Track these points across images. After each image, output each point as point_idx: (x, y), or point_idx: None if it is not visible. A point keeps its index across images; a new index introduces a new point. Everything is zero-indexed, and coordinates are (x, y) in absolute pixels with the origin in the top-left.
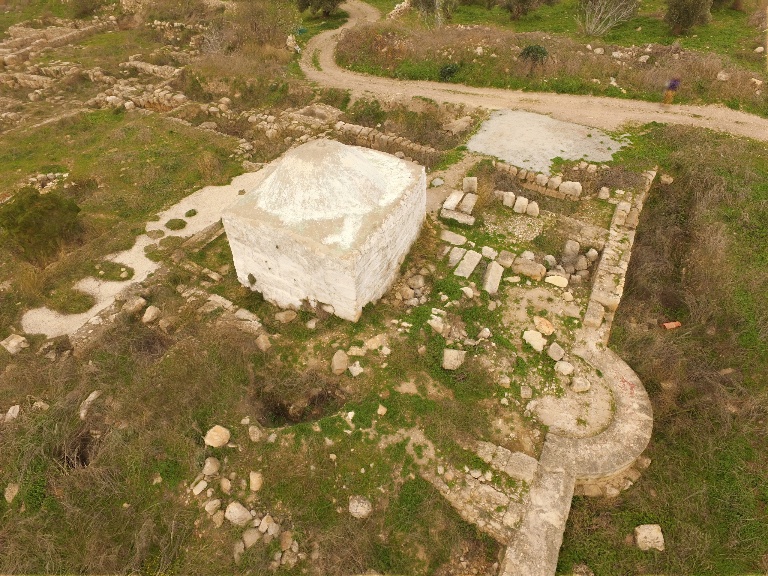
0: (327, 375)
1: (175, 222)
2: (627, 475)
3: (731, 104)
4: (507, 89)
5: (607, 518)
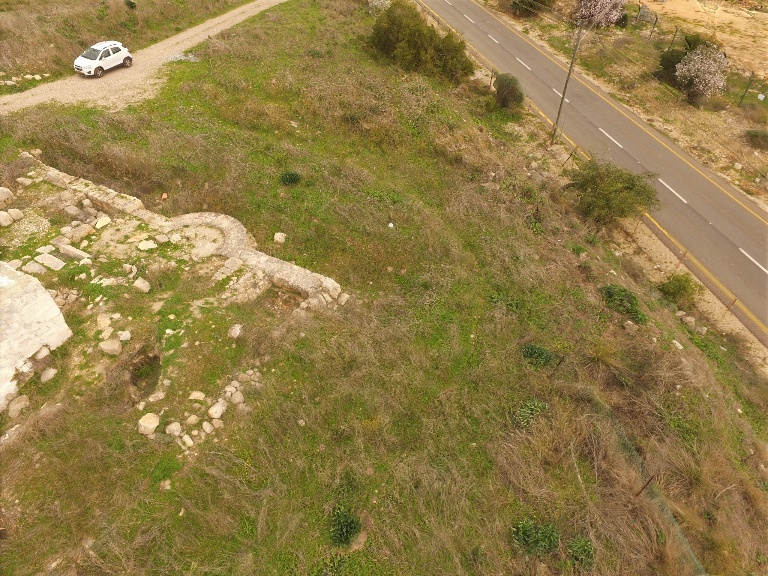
0: (117, 360)
1: None
2: (248, 237)
3: None
4: None
5: (267, 250)
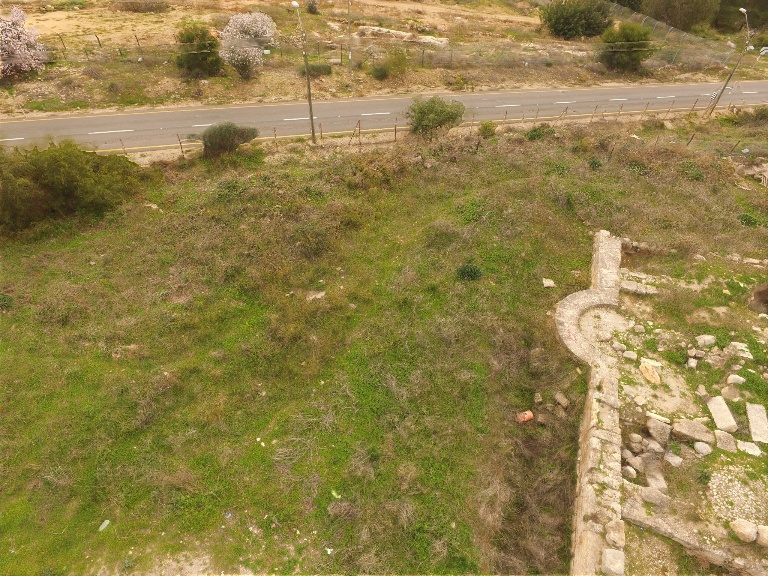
0: None
1: None
2: None
3: None
4: None
5: None
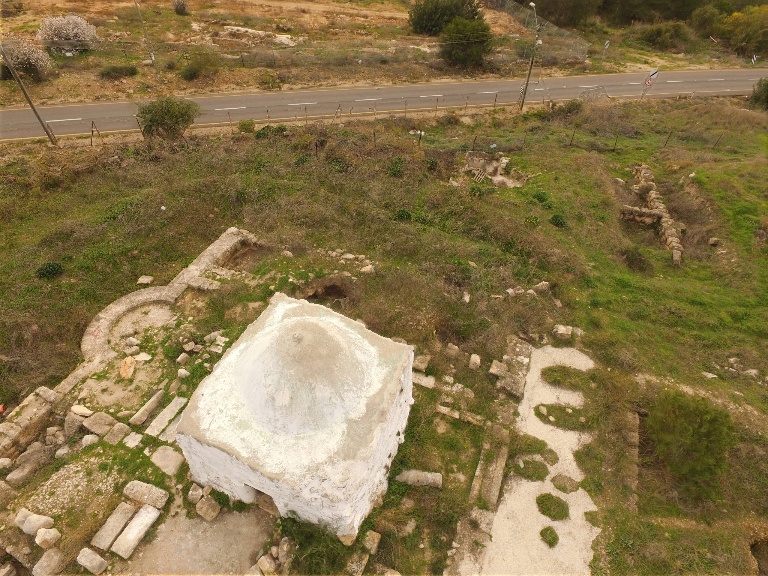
0: None
1: (557, 510)
2: None
3: None
4: None
5: None
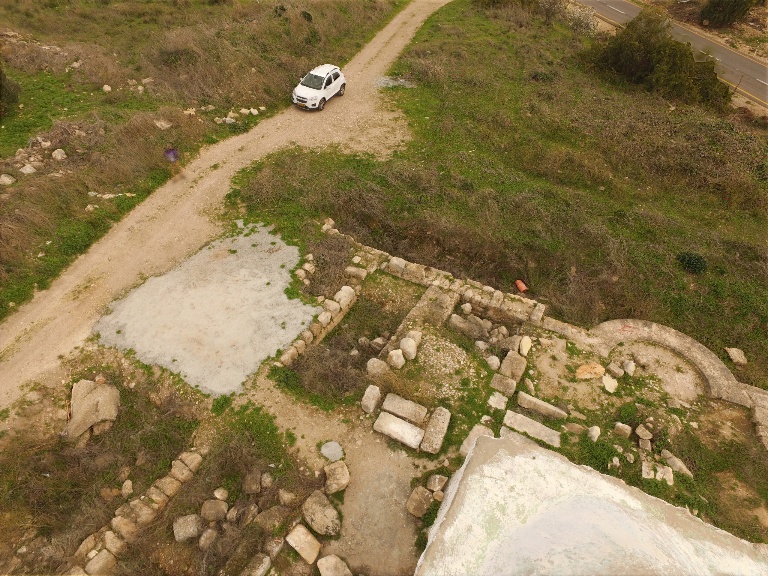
0: None
1: None
2: None
3: (211, 140)
4: (18, 308)
5: None
